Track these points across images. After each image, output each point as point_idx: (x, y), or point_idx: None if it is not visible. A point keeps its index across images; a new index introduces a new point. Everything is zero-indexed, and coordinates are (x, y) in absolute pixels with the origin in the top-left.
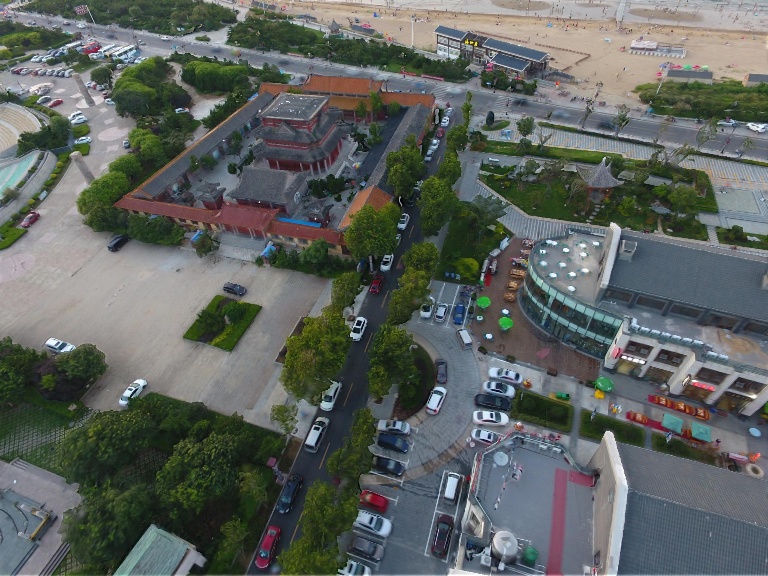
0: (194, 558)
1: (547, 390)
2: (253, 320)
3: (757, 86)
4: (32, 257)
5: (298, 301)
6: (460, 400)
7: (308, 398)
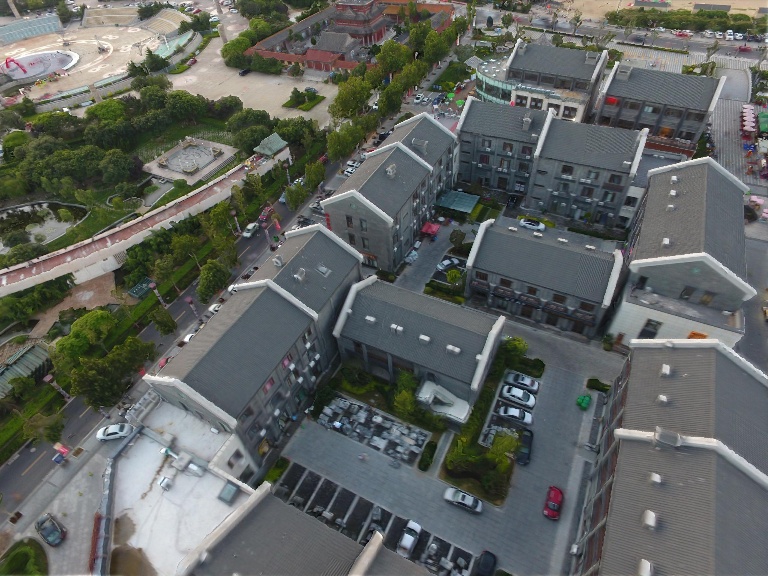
0: None
1: None
2: (320, 102)
3: (697, 12)
4: (195, 77)
5: None
6: None
7: (346, 111)
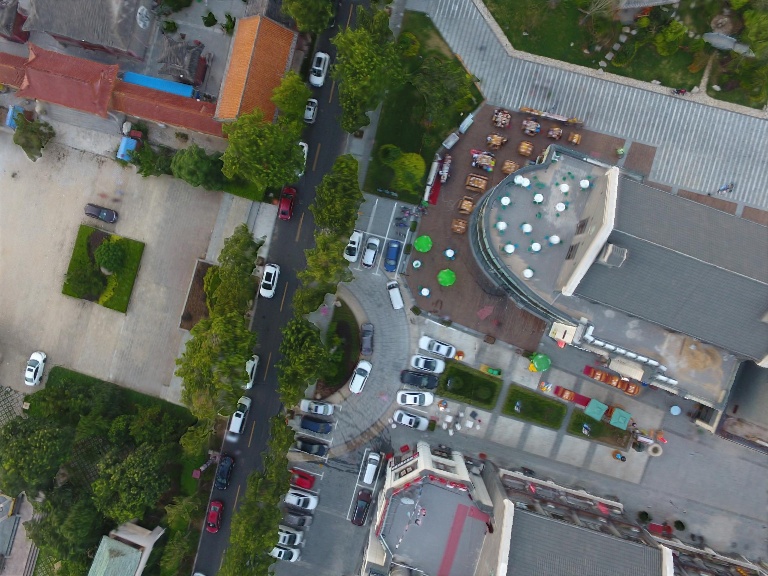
0: (152, 543)
1: (480, 361)
2: (139, 265)
3: None
4: None
5: (189, 232)
6: (386, 374)
7: None
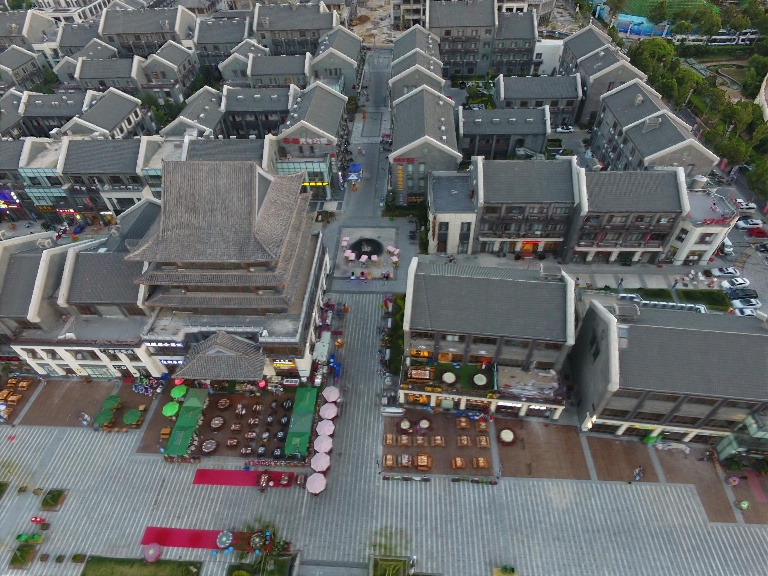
0: None
1: None
2: None
3: None
4: None
5: None
6: (765, 295)
7: None
